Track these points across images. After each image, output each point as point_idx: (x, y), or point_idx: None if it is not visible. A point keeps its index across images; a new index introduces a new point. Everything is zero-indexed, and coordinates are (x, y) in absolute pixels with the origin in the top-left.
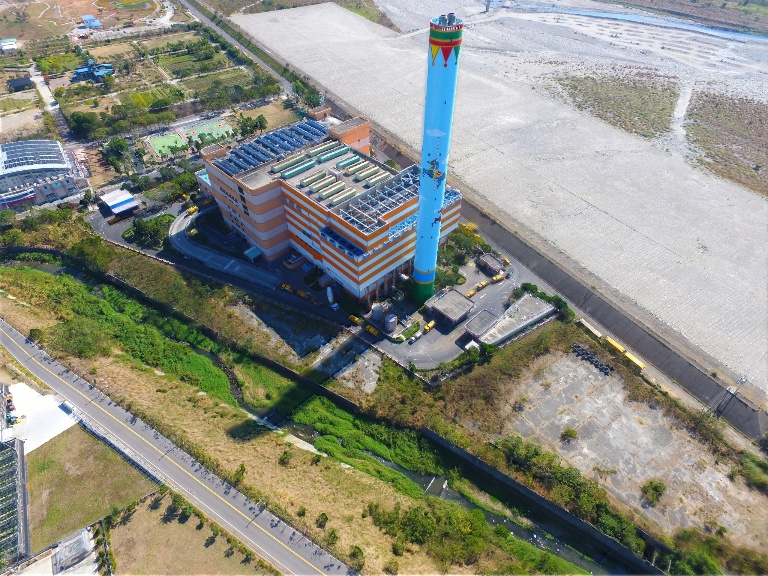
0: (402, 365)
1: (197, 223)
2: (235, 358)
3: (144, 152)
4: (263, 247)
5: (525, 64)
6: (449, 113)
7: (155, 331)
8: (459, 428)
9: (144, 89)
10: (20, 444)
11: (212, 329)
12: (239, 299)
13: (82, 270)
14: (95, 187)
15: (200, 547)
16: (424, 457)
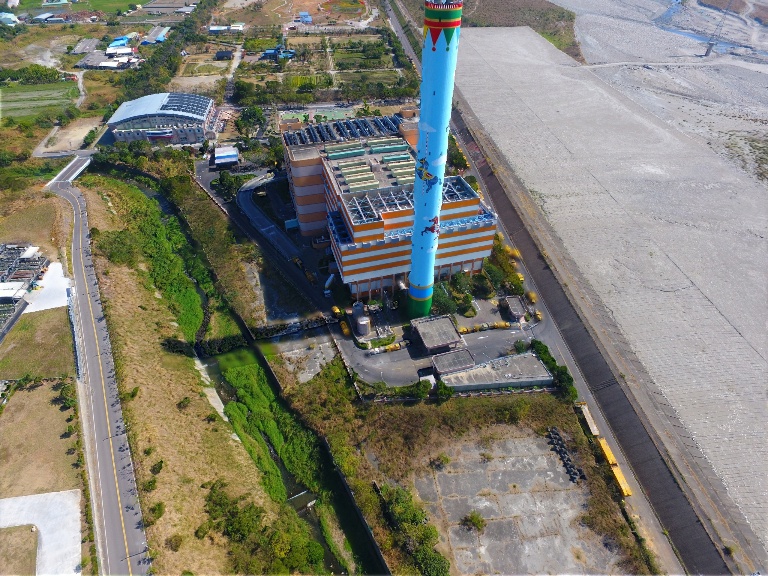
0: (348, 370)
1: (268, 187)
2: (219, 306)
3: (264, 120)
4: (299, 220)
5: (717, 116)
6: (440, 107)
7: (179, 262)
8: (359, 455)
9: (306, 74)
10: (24, 304)
11: (217, 275)
12: (255, 259)
13: (167, 200)
14: (219, 141)
15: (57, 436)
16: (307, 466)
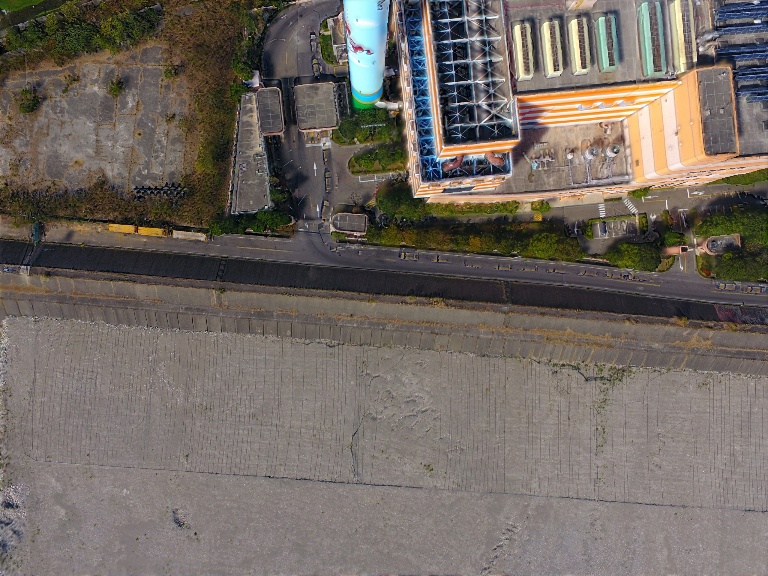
0: (292, 2)
1: None
2: None
3: None
4: None
5: None
6: None
7: None
8: None
9: None
10: None
11: None
12: None
13: None
14: None
15: None
16: None
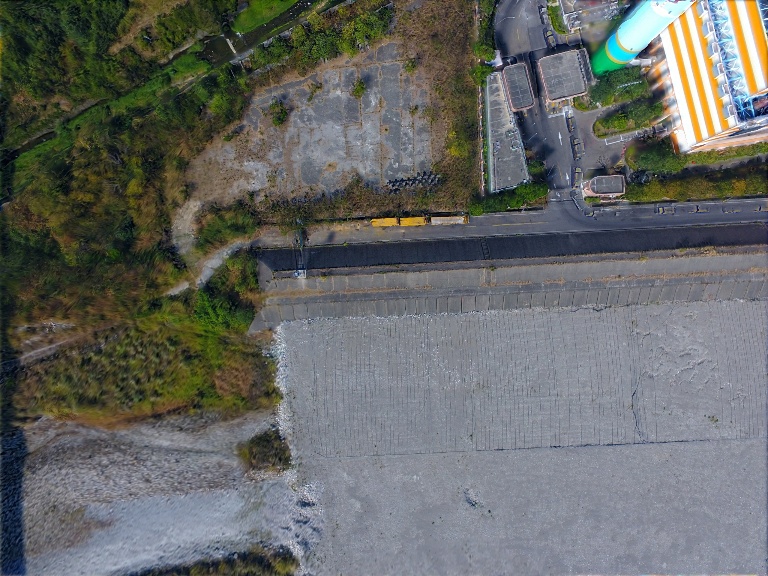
0: None
1: None
2: None
3: None
4: None
5: None
6: None
7: None
8: None
9: None
10: None
11: None
12: None
13: None
14: None
15: None
16: None
